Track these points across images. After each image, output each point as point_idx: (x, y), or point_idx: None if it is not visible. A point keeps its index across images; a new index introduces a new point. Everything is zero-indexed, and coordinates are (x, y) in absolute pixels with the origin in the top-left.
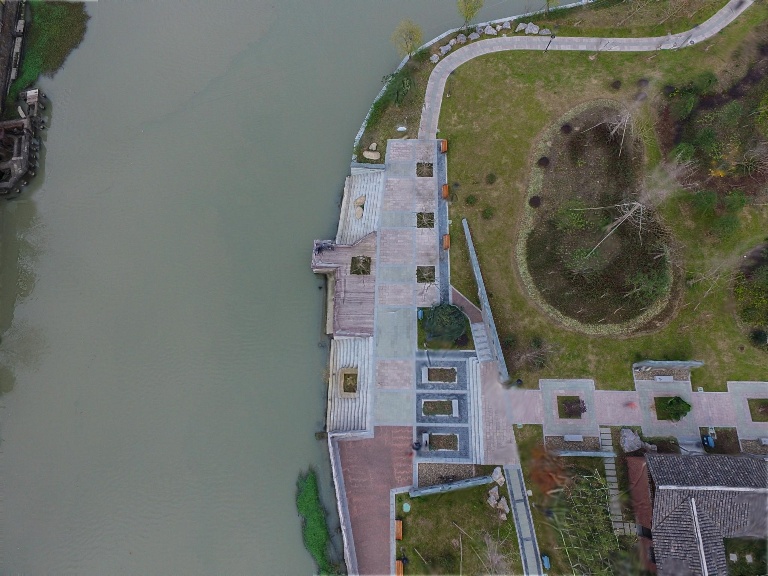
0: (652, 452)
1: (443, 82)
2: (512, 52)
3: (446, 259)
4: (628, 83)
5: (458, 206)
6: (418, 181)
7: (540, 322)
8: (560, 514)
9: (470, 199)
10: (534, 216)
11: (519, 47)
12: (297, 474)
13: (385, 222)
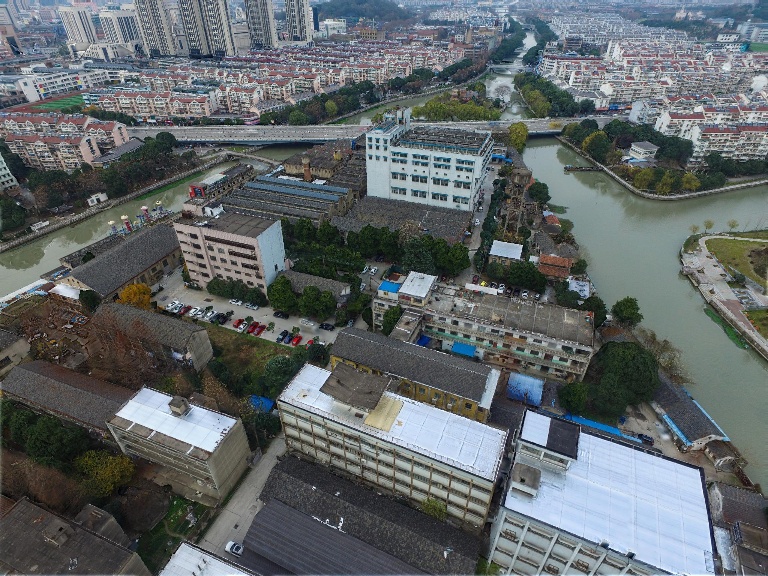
0: None
1: (704, 242)
2: None
3: (728, 273)
4: (767, 246)
5: (725, 264)
6: (708, 259)
7: (767, 284)
8: None
9: (729, 262)
10: (753, 265)
11: (725, 238)
12: (704, 309)
13: (703, 265)
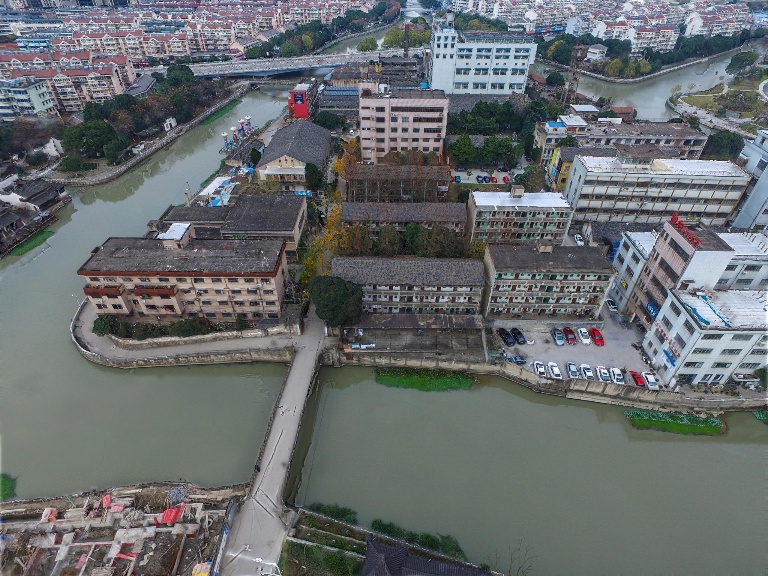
0: None
1: None
2: (689, 96)
3: None
4: None
5: None
6: None
7: None
8: None
9: (706, 106)
10: (721, 105)
11: None
12: (713, 131)
13: None
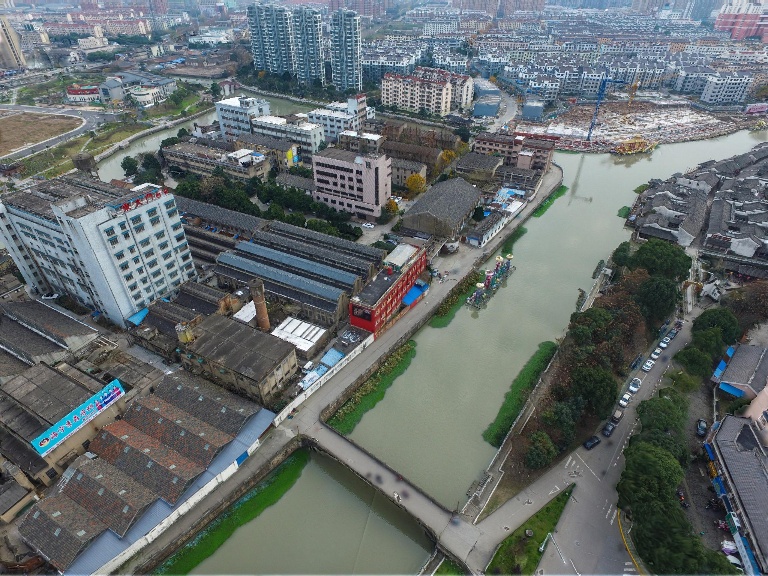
0: (7, 174)
1: None
2: None
3: None
4: None
5: None
6: None
7: None
8: (28, 171)
9: None
10: None
11: None
12: None
13: None
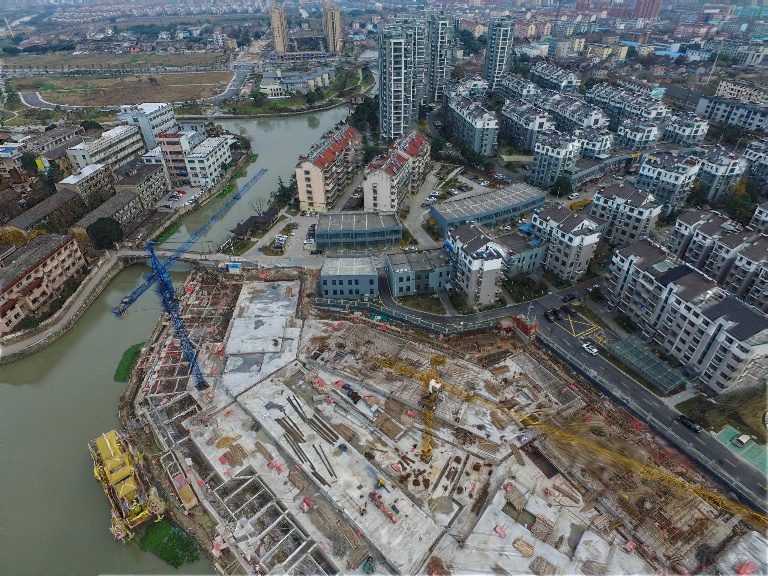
0: None
1: None
2: None
3: None
4: None
5: None
6: None
7: None
8: None
9: None
10: None
11: None
12: None
13: None
